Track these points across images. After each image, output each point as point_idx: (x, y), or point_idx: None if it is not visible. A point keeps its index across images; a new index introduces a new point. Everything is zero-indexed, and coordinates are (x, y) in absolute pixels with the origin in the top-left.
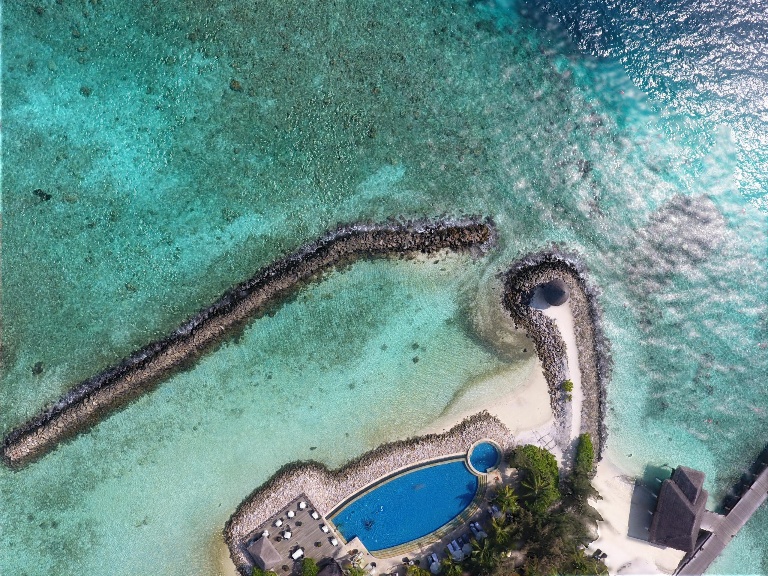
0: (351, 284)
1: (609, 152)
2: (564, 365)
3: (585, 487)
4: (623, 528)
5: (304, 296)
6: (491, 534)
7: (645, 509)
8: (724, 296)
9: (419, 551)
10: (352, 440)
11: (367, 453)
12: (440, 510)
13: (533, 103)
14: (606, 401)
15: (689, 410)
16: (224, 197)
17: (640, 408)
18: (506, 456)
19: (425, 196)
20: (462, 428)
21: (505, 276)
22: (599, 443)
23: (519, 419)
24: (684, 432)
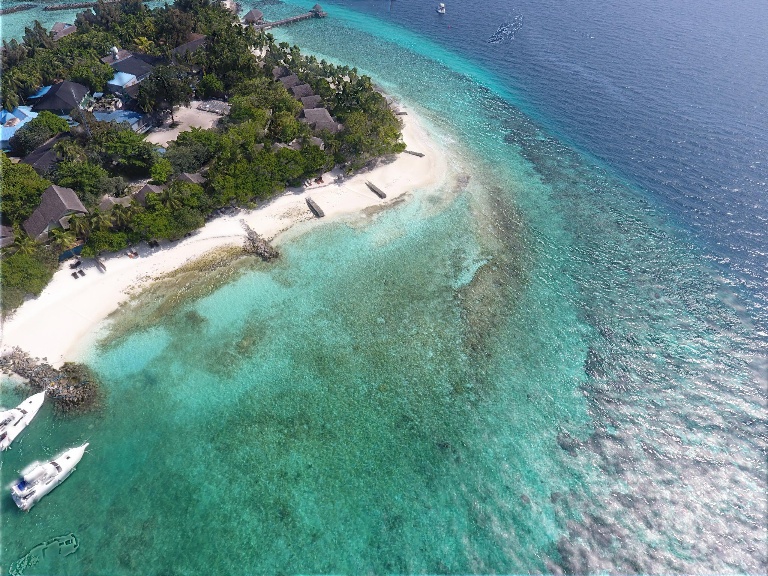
0: (167, 1)
1: None
2: None
3: None
4: None
5: None
6: None
7: None
8: (281, 8)
9: None
10: None
11: None
12: None
13: None
14: None
15: None
16: None
17: None
18: None
19: None
20: None
21: None
22: None
23: None
24: None
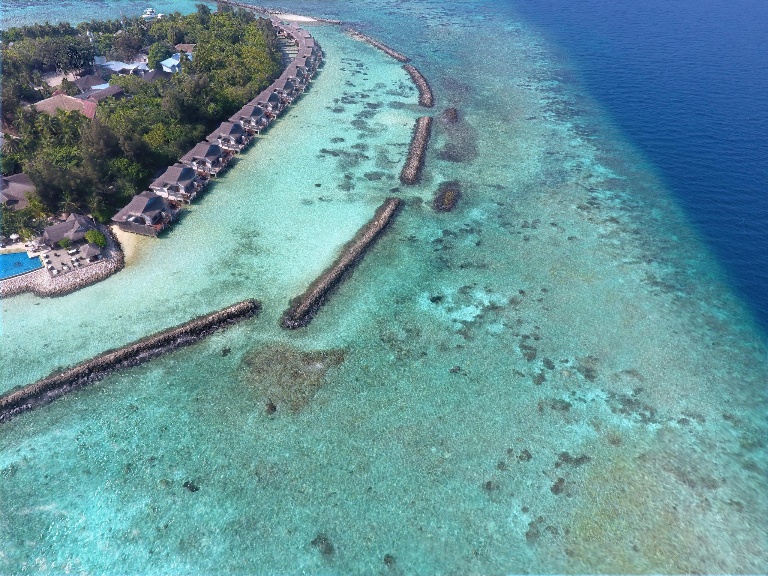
0: None
1: None
2: None
3: None
4: None
5: None
6: None
7: None
8: None
9: None
10: (4, 308)
11: None
12: None
13: None
14: None
15: None
16: (5, 490)
17: None
18: None
19: None
20: None
21: None
22: None
23: None
24: None
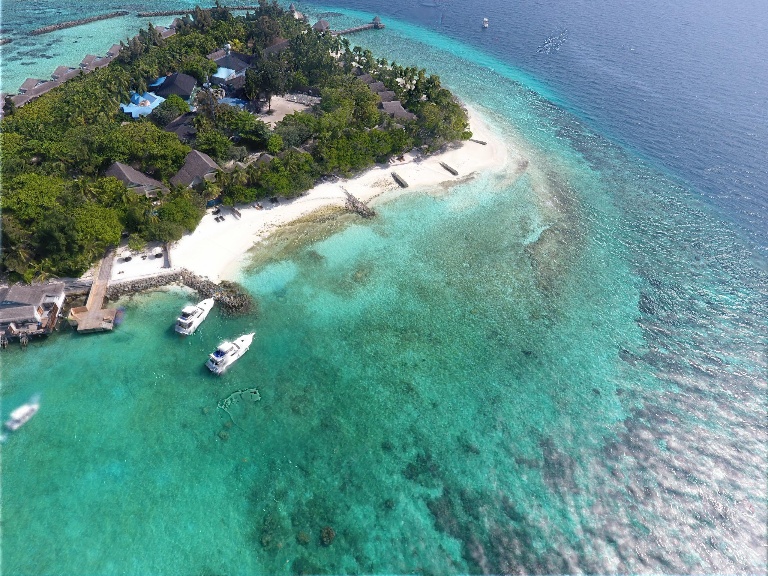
0: None
1: (313, 8)
2: None
3: None
4: None
5: None
6: None
7: None
8: None
9: None
10: None
11: None
12: None
13: (295, 4)
14: None
15: None
16: (212, 4)
17: None
18: None
19: None
20: None
21: None
22: None
23: None
24: None
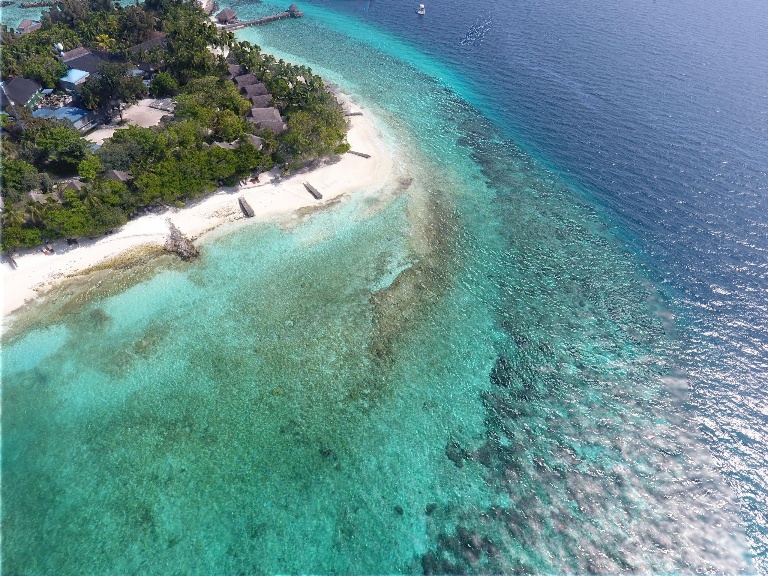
0: None
1: None
2: None
3: None
4: None
5: None
6: None
7: None
8: None
9: None
10: None
11: None
12: None
13: None
14: None
15: None
16: None
17: None
18: None
19: None
20: None
21: None
22: None
23: None
24: None
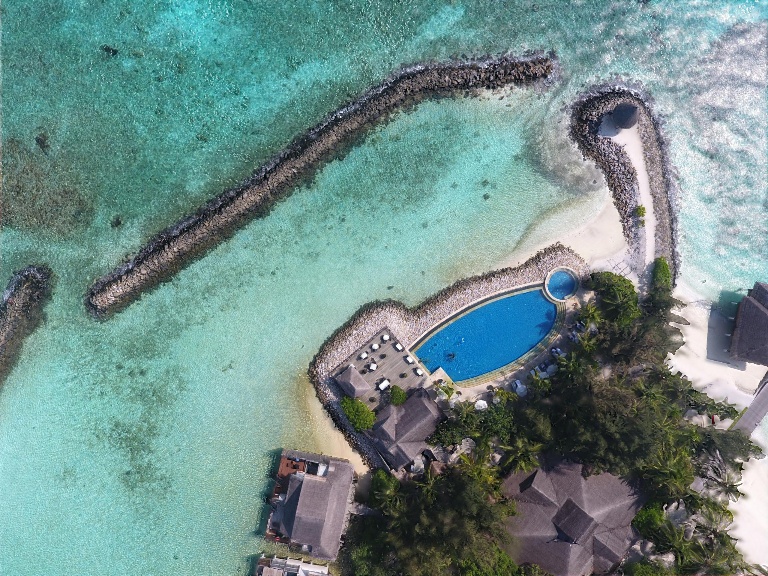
0: (418, 125)
1: None
2: (635, 191)
3: (668, 298)
4: (702, 351)
5: (372, 138)
6: (577, 348)
7: (722, 333)
8: None
9: (503, 379)
10: (428, 278)
11: (444, 289)
12: (520, 339)
13: None
14: (677, 229)
15: (760, 235)
16: (287, 44)
17: (711, 235)
18: (583, 283)
19: (486, 34)
20: (537, 260)
21: (570, 109)
22: (673, 269)
23: (593, 249)
24: (756, 257)
